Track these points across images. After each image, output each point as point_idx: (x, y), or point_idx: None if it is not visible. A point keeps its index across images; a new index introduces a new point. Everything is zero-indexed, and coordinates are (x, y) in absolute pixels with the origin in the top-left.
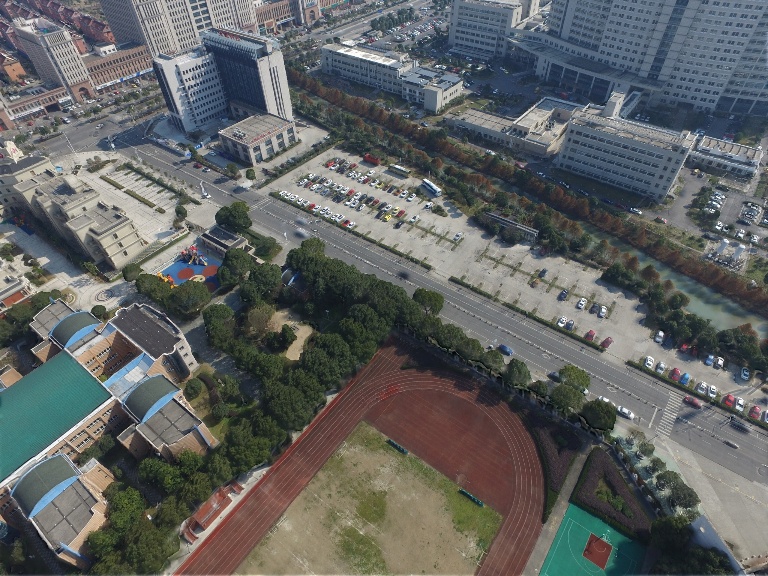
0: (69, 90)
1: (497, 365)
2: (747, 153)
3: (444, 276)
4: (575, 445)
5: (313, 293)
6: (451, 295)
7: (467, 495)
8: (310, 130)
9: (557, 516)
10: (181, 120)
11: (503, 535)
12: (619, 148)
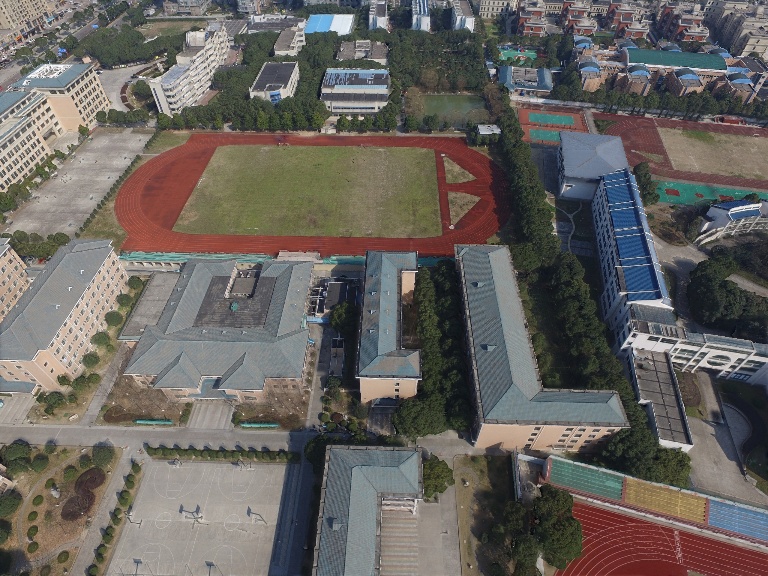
0: None
1: None
2: None
3: None
4: None
5: None
6: None
7: None
8: None
9: None
10: None
11: None
12: None
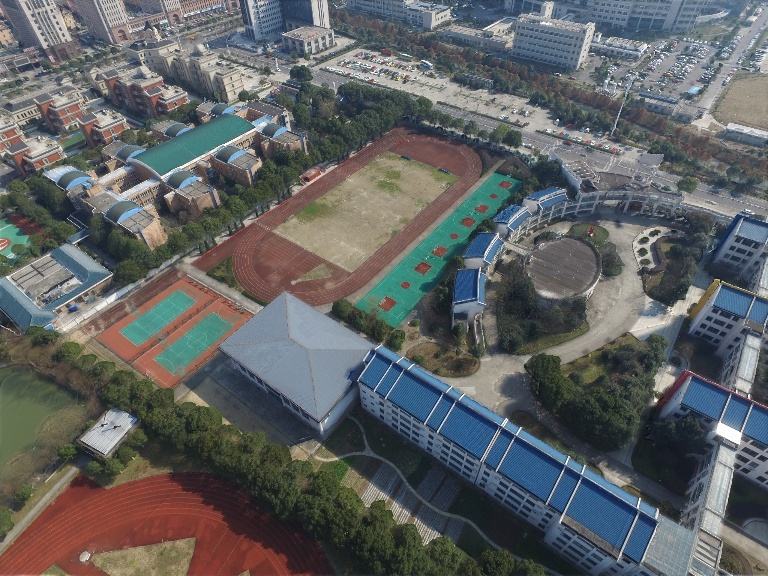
0: (167, 15)
1: (461, 124)
2: (636, 45)
3: (434, 102)
4: (500, 155)
5: (355, 105)
6: (437, 108)
7: (442, 170)
8: (342, 39)
9: (487, 176)
10: (253, 30)
11: (459, 181)
12: (548, 35)
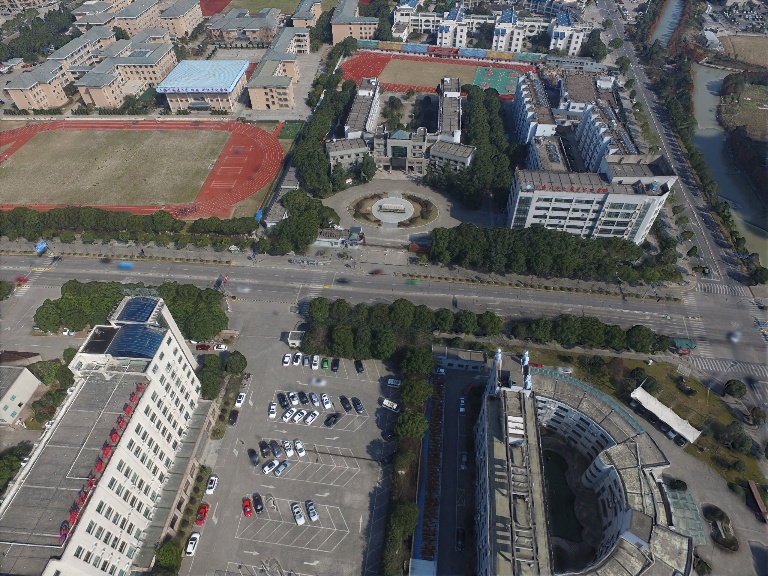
0: None
1: None
2: None
3: None
4: (577, 1)
5: None
6: None
7: None
8: None
9: None
10: None
11: None
12: None
